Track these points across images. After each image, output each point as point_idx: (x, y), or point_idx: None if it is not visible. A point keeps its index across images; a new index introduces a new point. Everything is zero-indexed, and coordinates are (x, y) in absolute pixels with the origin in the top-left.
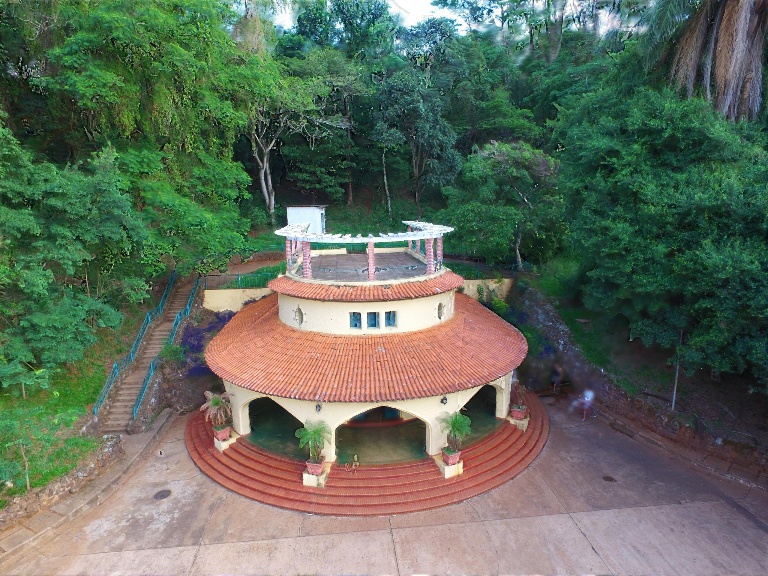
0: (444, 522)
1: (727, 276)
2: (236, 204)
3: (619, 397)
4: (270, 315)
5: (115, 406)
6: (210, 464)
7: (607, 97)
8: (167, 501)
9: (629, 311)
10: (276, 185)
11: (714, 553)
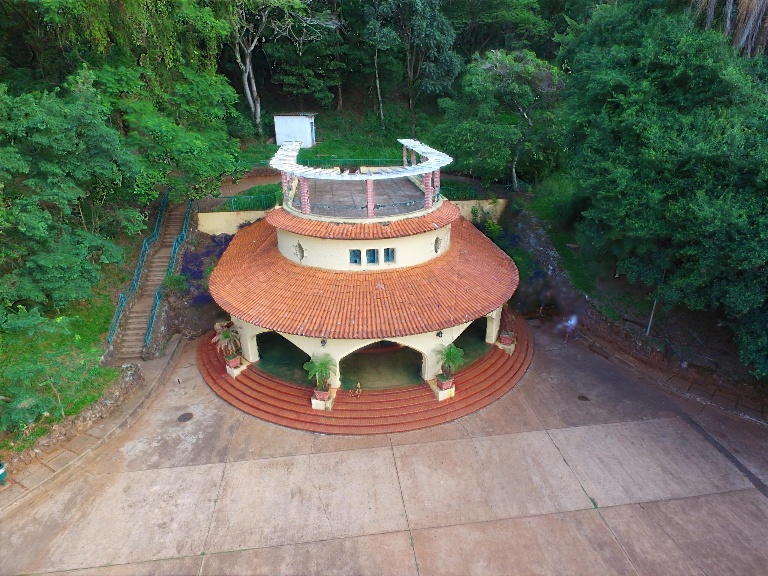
0: (438, 439)
1: (714, 229)
2: (223, 120)
3: (600, 322)
4: (269, 245)
5: (127, 334)
6: (225, 389)
7: (622, 18)
8: (190, 423)
9: (618, 250)
10: (260, 87)
11: (665, 463)
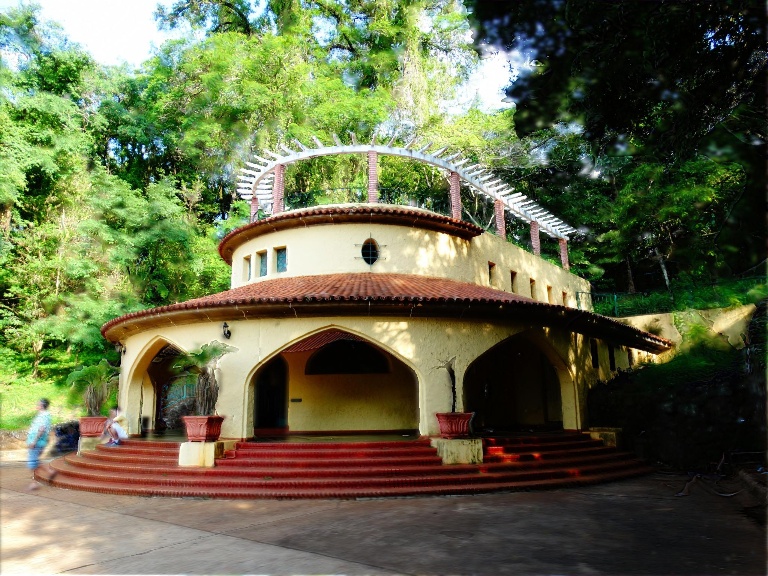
0: (75, 501)
1: None
2: None
3: None
4: None
5: None
6: None
7: None
8: None
9: None
10: None
11: None
